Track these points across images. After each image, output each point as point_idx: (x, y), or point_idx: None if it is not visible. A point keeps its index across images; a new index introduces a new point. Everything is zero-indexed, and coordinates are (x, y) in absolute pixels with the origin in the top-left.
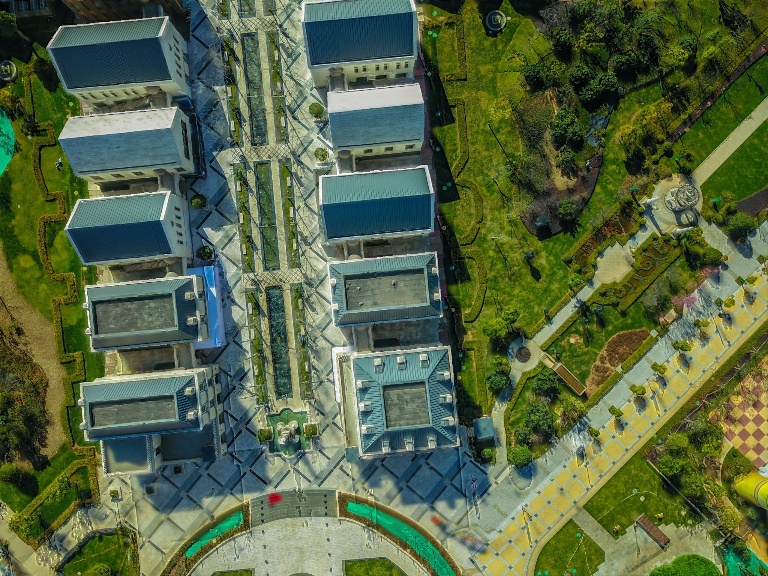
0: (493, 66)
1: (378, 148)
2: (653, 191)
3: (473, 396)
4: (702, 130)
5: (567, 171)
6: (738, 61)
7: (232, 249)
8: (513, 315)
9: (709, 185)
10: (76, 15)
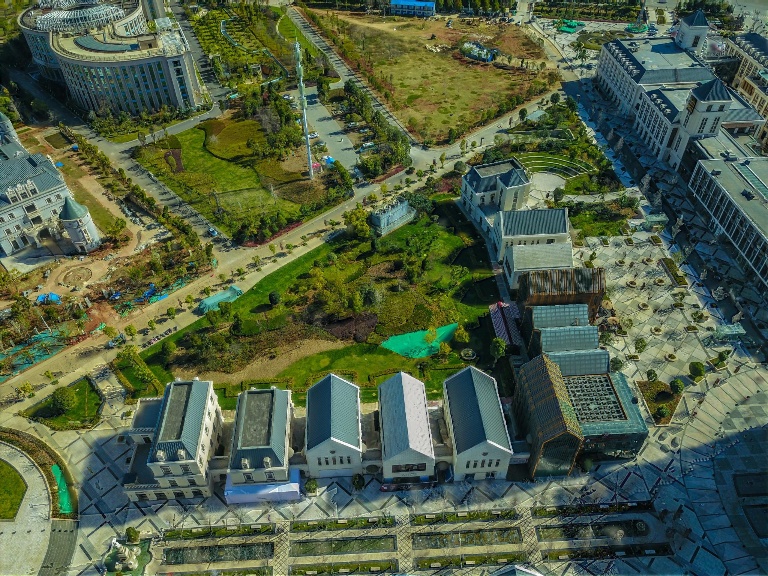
0: None
1: None
2: None
3: None
4: None
5: None
6: None
7: (315, 512)
8: None
9: None
10: None
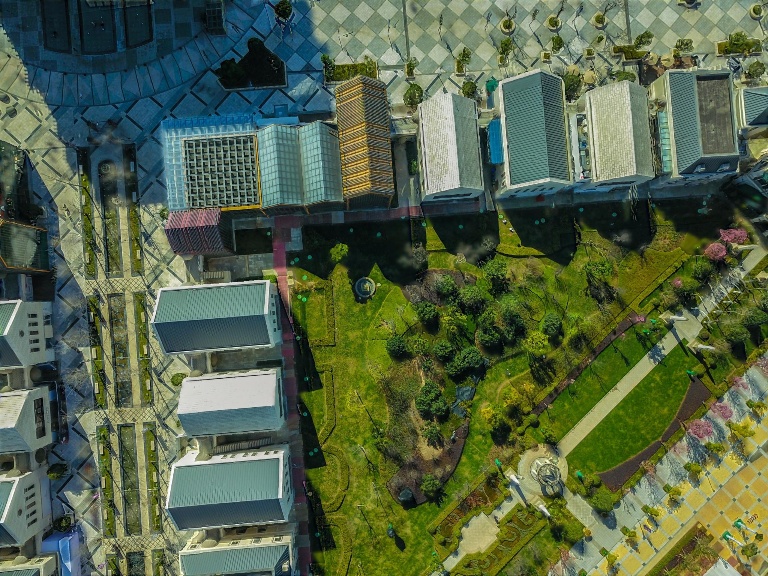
0: (362, 332)
1: None
2: (519, 461)
3: None
4: (568, 401)
5: (433, 440)
6: (604, 334)
7: (93, 514)
8: None
9: (574, 455)
10: None
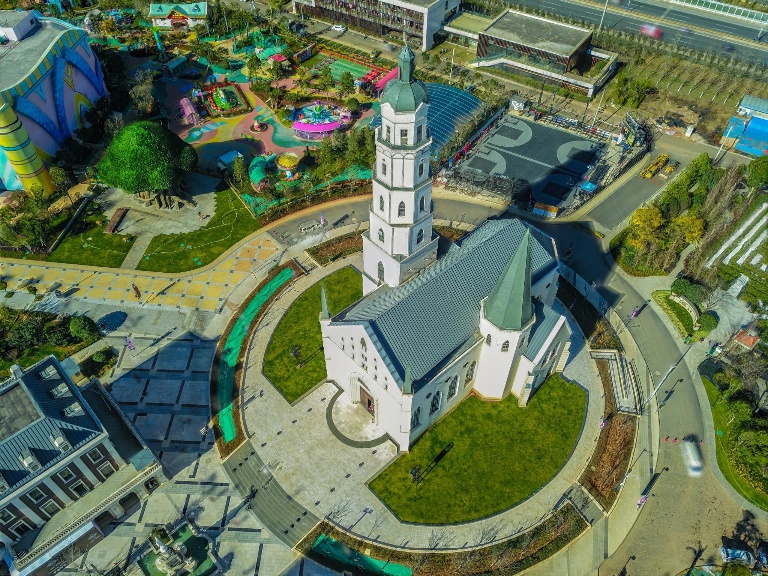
0: None
1: None
2: None
3: None
4: None
5: None
6: None
7: None
8: None
9: None
10: None
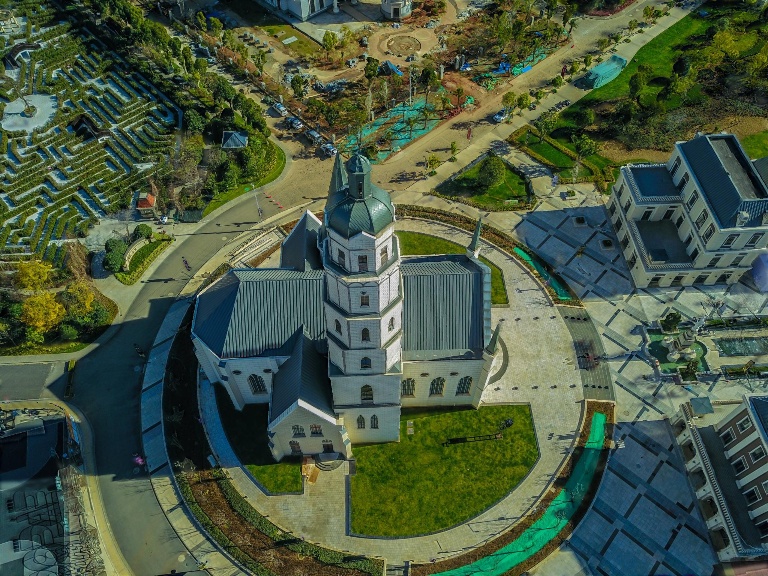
0: None
1: None
2: None
3: None
4: None
5: None
6: None
7: None
8: None
9: None
10: None
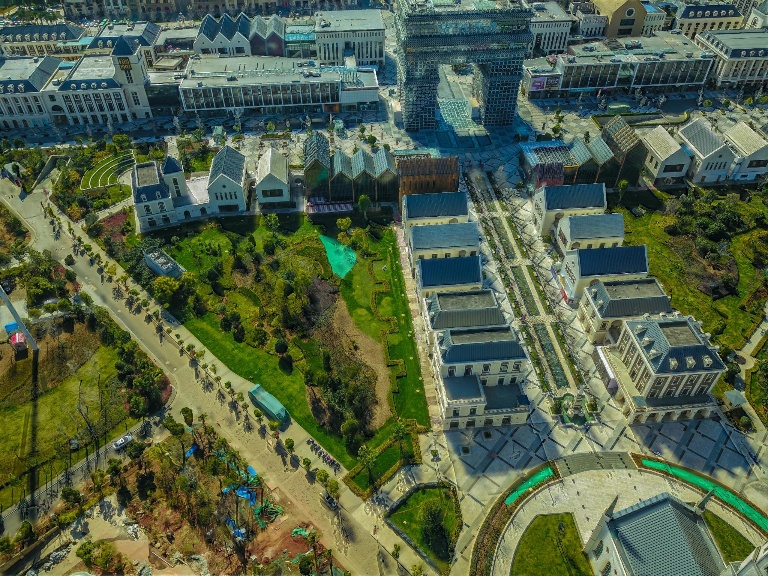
0: (645, 228)
1: (596, 244)
2: None
3: (714, 386)
4: None
5: (716, 267)
6: None
7: (504, 306)
8: (723, 321)
9: None
10: (394, 212)
